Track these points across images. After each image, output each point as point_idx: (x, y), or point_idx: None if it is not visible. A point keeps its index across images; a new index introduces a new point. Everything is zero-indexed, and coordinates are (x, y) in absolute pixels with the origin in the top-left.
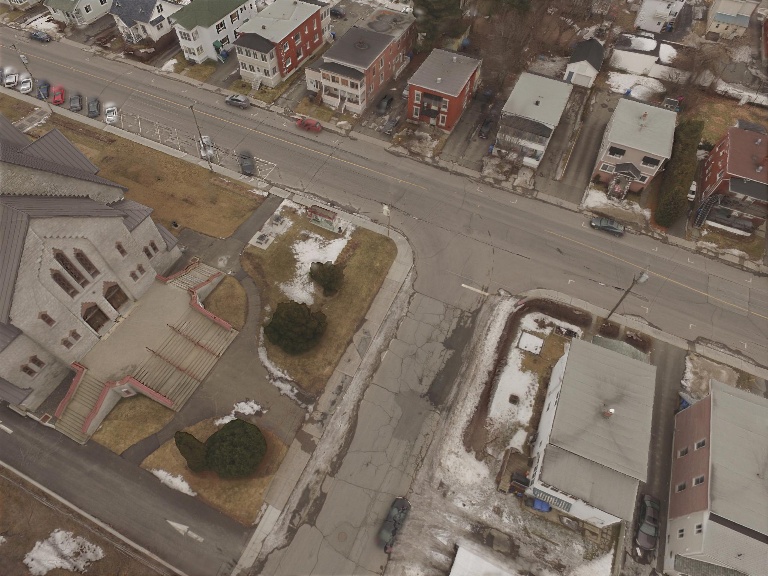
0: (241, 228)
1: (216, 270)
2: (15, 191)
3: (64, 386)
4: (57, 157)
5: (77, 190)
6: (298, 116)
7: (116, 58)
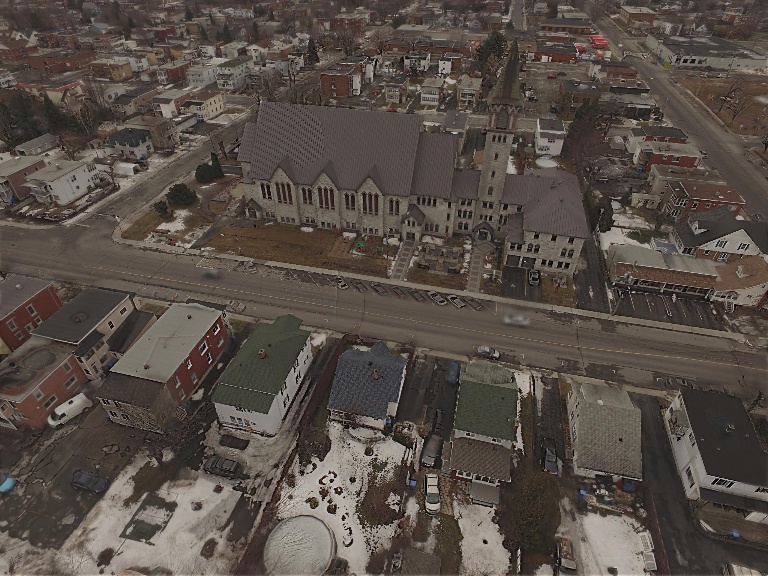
0: None
1: (226, 214)
2: None
3: None
4: None
5: None
6: None
7: None
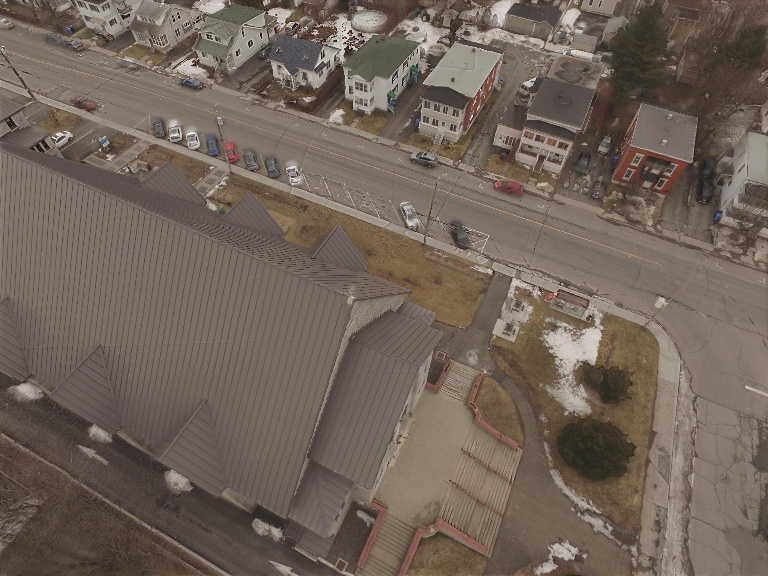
0: (478, 315)
1: (471, 369)
2: (364, 323)
3: (349, 521)
4: (339, 257)
5: (388, 305)
6: (492, 176)
7: (277, 108)
